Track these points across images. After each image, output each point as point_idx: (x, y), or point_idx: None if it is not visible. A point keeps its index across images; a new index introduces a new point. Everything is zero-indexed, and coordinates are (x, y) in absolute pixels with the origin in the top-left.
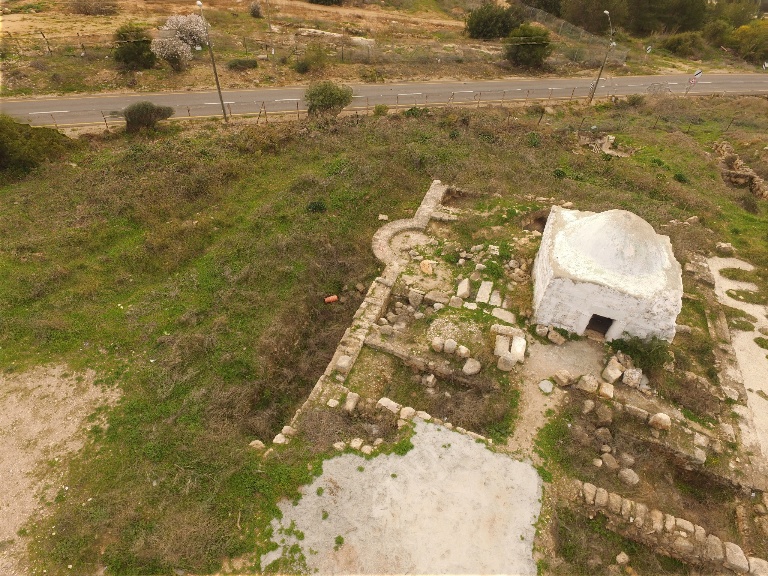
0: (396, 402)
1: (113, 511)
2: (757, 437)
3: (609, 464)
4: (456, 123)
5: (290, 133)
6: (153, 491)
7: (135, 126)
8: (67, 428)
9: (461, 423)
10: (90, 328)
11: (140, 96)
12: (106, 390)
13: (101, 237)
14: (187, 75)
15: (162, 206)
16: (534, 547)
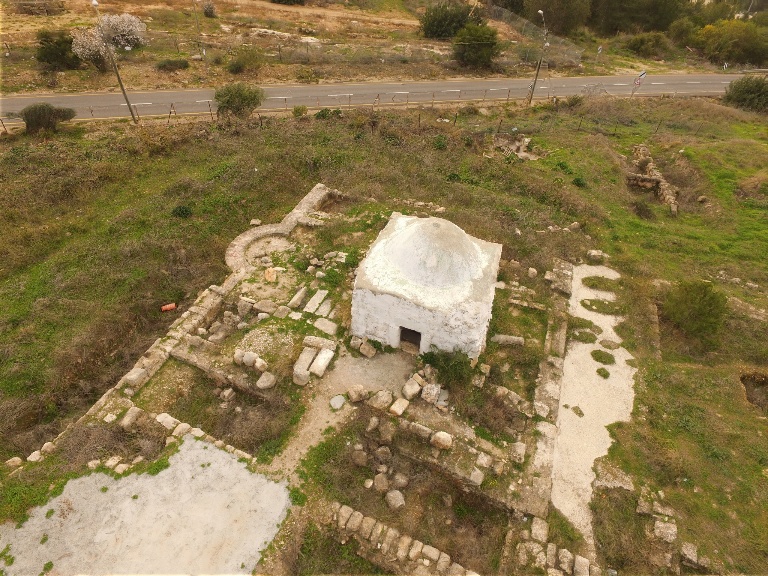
0: (186, 417)
1: None
2: (551, 457)
3: (377, 485)
4: (364, 125)
5: (185, 135)
6: None
7: (35, 128)
8: None
9: (235, 440)
10: None
11: (56, 97)
12: None
13: None
14: (112, 76)
15: (16, 210)
16: (254, 575)
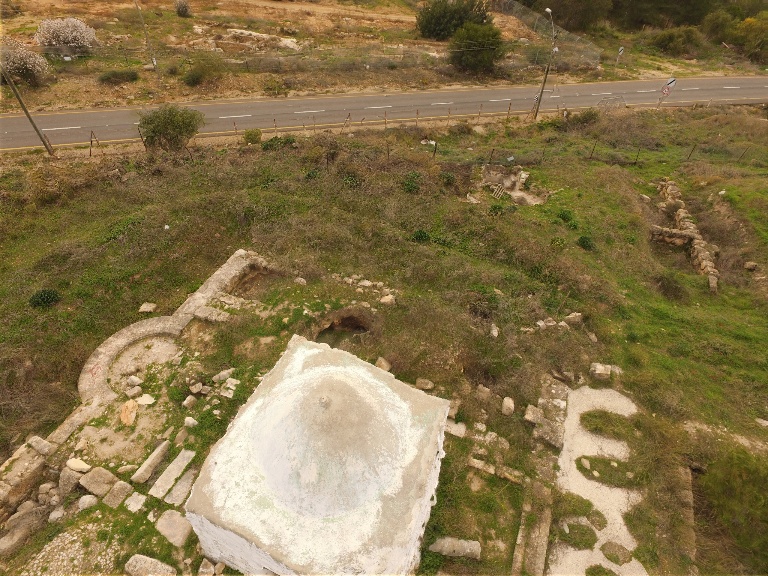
0: None
1: None
2: None
3: None
4: (318, 159)
5: (89, 177)
6: None
7: None
8: None
9: None
10: None
11: None
12: None
13: None
14: (46, 91)
15: None
16: None
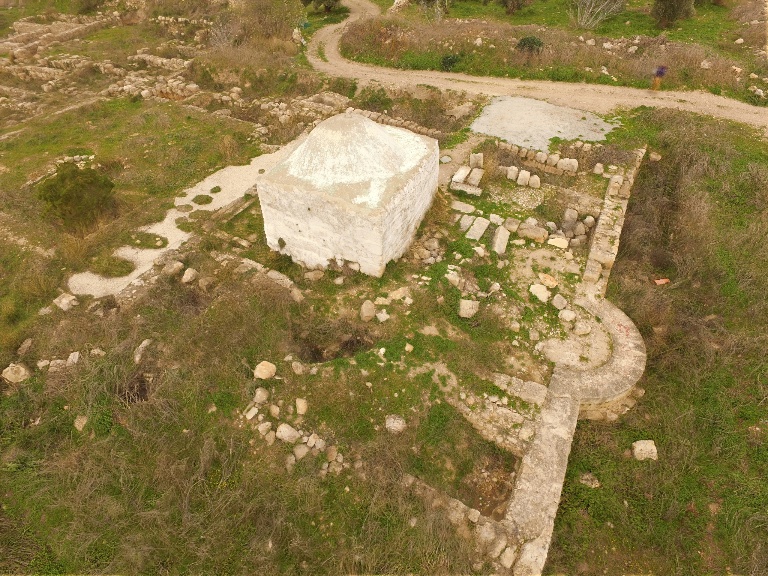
0: None
1: None
2: None
3: None
4: None
5: None
6: None
7: None
8: None
9: None
10: None
11: None
12: None
13: None
14: None
15: None
16: None
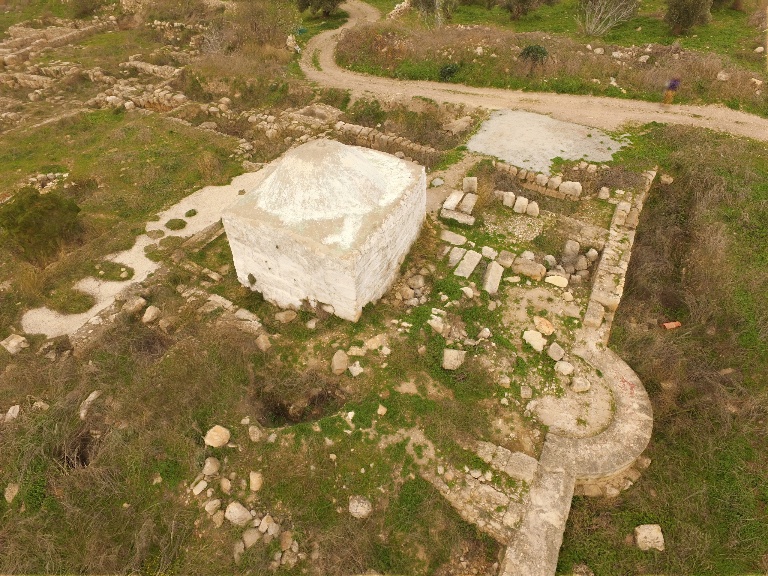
0: None
1: None
2: None
3: None
4: None
5: None
6: None
7: None
8: None
9: None
10: None
11: None
12: None
13: None
14: None
15: None
16: None
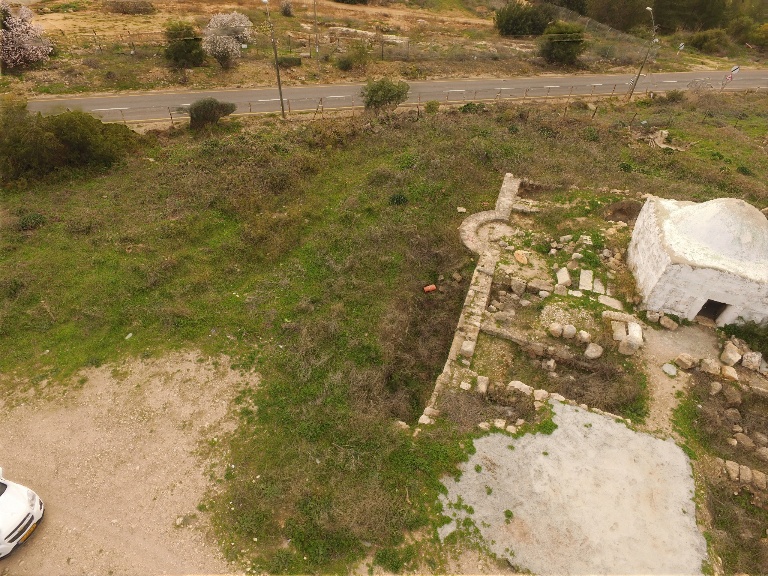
0: None
1: (284, 487)
2: None
3: (745, 443)
4: (514, 118)
5: (356, 128)
6: (320, 468)
7: (199, 122)
8: (217, 410)
9: (594, 404)
10: (213, 315)
11: (194, 93)
12: (245, 374)
13: (198, 229)
14: (235, 73)
15: (252, 199)
16: (696, 520)
